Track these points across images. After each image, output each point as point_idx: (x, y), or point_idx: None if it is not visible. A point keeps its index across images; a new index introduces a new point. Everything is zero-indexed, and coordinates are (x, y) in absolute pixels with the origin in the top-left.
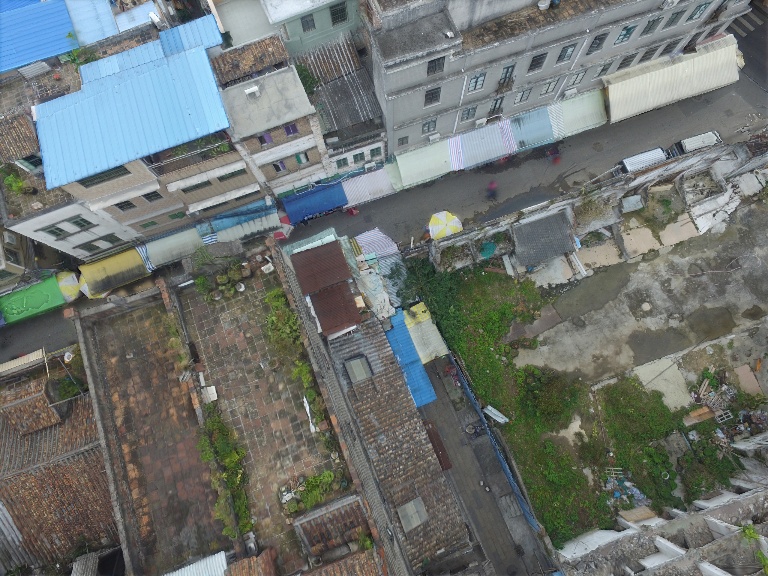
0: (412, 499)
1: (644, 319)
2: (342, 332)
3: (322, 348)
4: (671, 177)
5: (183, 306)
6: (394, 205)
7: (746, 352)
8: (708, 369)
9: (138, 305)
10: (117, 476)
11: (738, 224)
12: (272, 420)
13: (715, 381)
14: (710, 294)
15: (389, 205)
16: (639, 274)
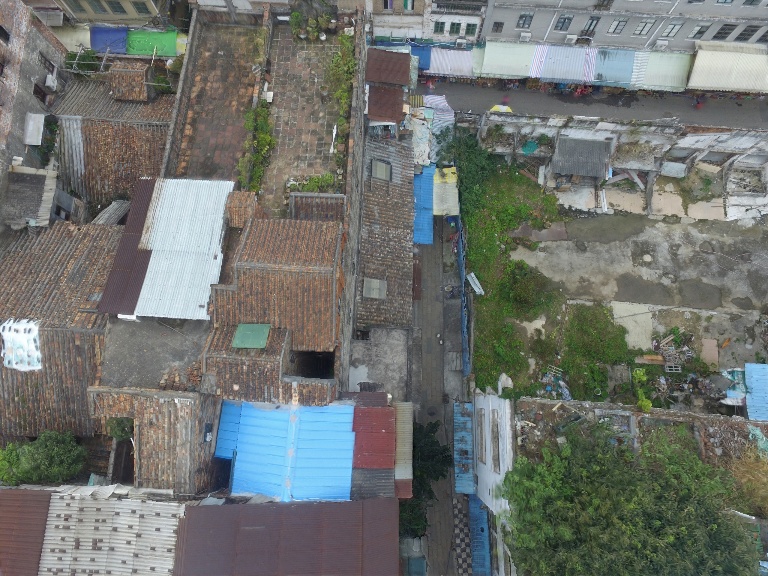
0: (379, 279)
1: (641, 267)
2: (382, 123)
3: (362, 123)
4: (722, 161)
5: (274, 35)
6: (467, 94)
7: (720, 330)
8: (678, 328)
9: (242, 23)
10: (177, 125)
11: (766, 226)
12: (304, 134)
13: (680, 339)
14: (711, 272)
15: (463, 92)
16: (654, 230)
